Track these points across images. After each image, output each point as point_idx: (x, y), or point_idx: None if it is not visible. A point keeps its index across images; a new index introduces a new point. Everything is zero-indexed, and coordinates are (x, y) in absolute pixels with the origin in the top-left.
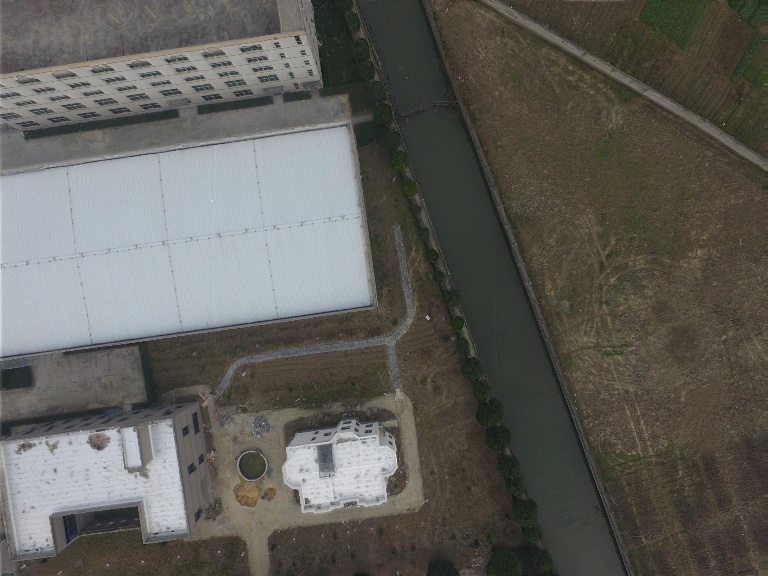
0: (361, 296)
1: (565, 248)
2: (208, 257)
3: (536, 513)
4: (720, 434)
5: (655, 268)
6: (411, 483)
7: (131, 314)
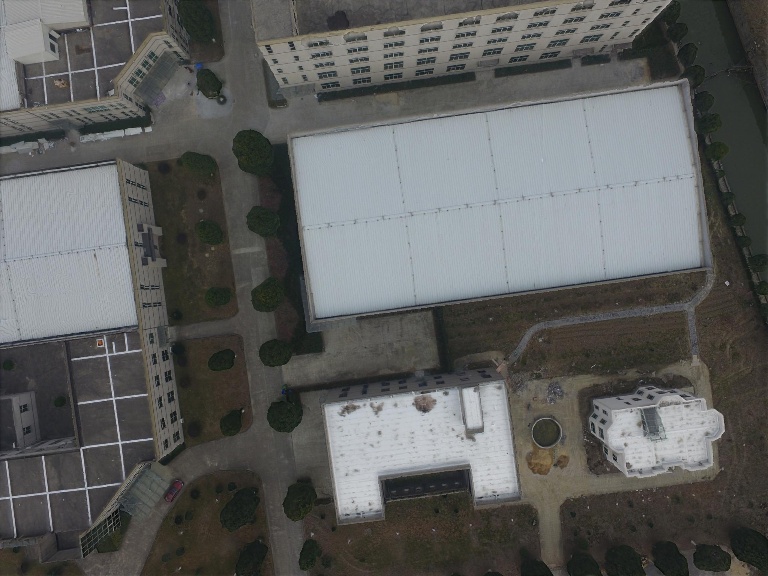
0: (691, 257)
1: None
2: (539, 217)
3: None
4: None
5: None
6: None
7: (457, 274)
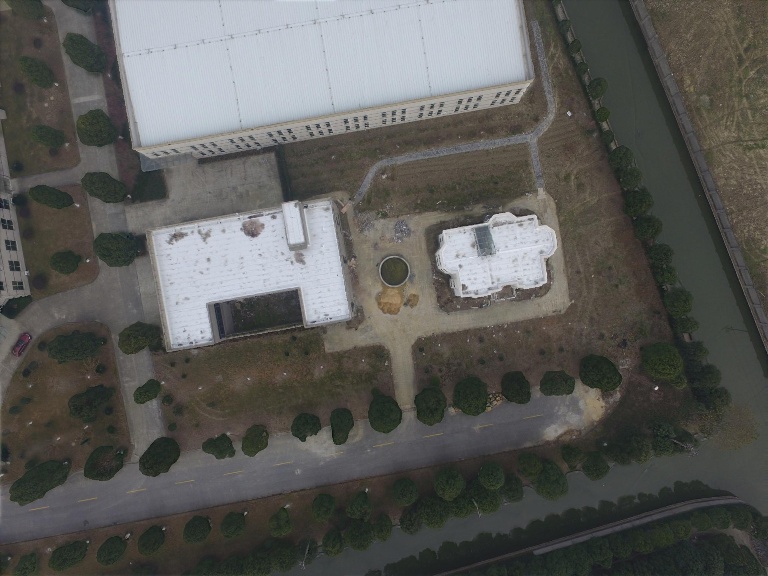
0: (516, 72)
1: (703, 42)
2: (360, 35)
3: None
4: None
5: None
6: (556, 284)
7: (282, 98)
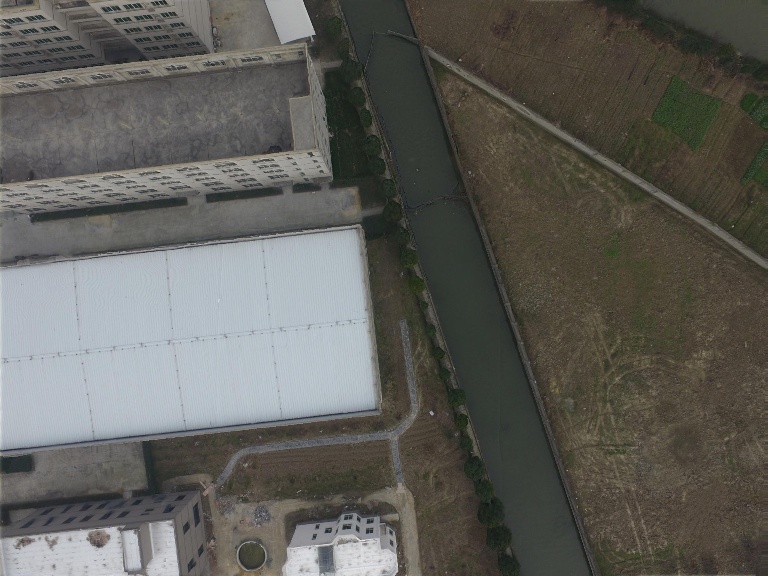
0: (366, 400)
1: (571, 346)
2: (214, 357)
3: None
4: (720, 535)
5: (660, 368)
6: None
7: (134, 411)
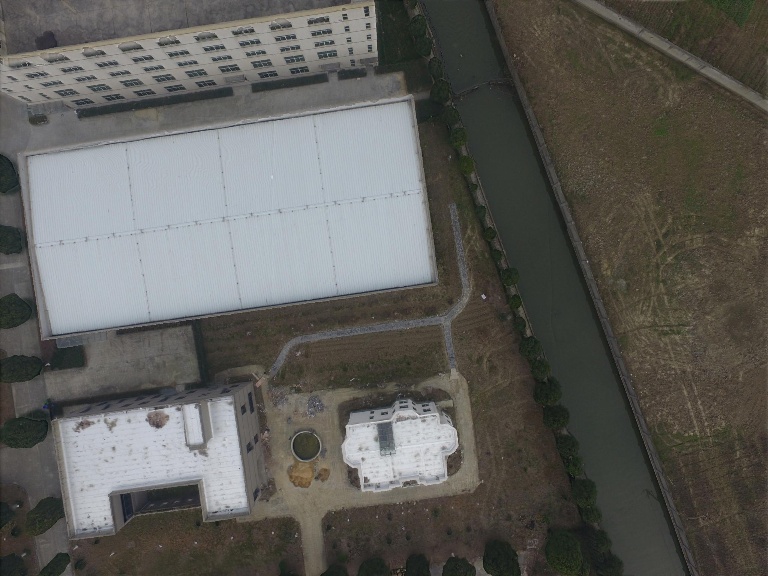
0: (422, 273)
1: (621, 227)
2: (268, 233)
3: (596, 493)
4: None
5: (712, 247)
6: (466, 464)
7: (190, 291)
